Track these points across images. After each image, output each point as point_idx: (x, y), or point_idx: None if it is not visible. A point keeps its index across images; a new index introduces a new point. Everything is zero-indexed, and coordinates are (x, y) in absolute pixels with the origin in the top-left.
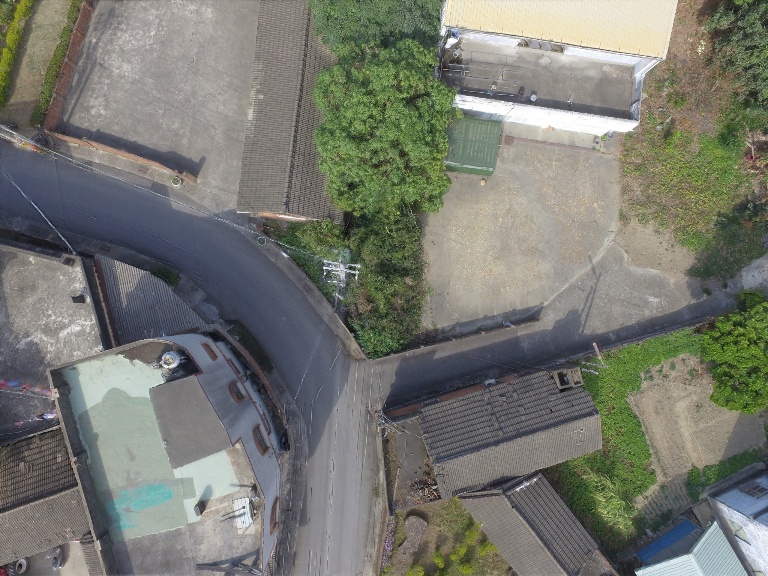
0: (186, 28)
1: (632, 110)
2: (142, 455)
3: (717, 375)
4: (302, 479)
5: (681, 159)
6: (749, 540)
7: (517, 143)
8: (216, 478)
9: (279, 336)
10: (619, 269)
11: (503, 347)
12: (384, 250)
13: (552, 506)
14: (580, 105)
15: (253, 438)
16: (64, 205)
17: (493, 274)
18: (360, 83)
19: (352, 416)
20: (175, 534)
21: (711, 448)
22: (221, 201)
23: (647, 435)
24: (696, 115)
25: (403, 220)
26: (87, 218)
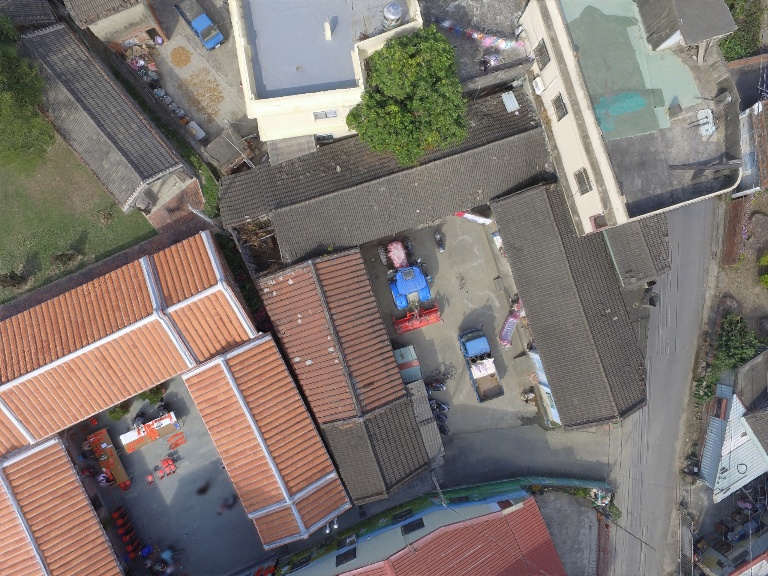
0: None
1: None
2: (616, 67)
3: None
4: None
5: None
6: None
7: None
8: (681, 91)
9: None
10: None
11: None
12: None
13: None
14: None
15: None
16: None
17: None
18: None
19: None
20: (649, 138)
21: None
22: None
23: None
24: None
25: None
26: None
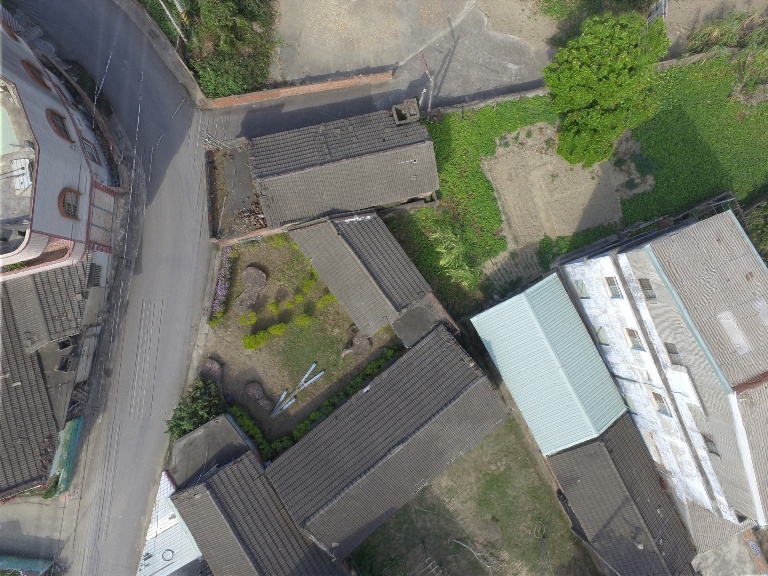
0: None
1: None
2: None
3: (564, 127)
4: (138, 227)
5: None
6: (588, 292)
7: None
8: None
9: (120, 80)
10: (478, 33)
11: (355, 105)
12: None
13: (385, 244)
14: None
15: (44, 111)
16: None
17: (347, 29)
18: None
19: (194, 166)
20: None
21: (565, 219)
22: None
23: (499, 201)
24: None
25: None
26: None
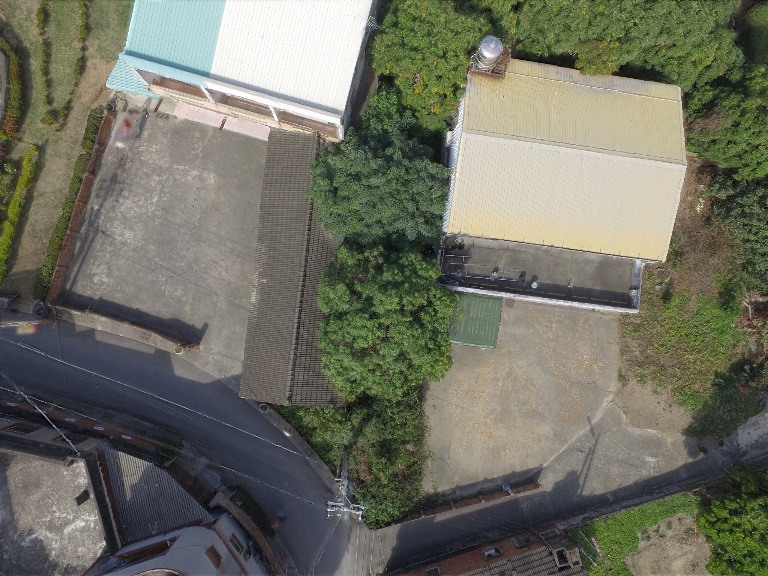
0: (188, 194)
1: (632, 295)
2: None
3: (713, 546)
4: None
5: (679, 319)
6: None
7: (517, 305)
8: None
9: (281, 501)
10: (617, 430)
11: (503, 509)
12: (386, 431)
13: None
14: (580, 288)
15: None
16: (67, 373)
17: (493, 437)
18: (363, 300)
19: None
20: None
21: None
22: (223, 367)
23: None
24: (694, 274)
25: (405, 400)
26: (90, 386)
